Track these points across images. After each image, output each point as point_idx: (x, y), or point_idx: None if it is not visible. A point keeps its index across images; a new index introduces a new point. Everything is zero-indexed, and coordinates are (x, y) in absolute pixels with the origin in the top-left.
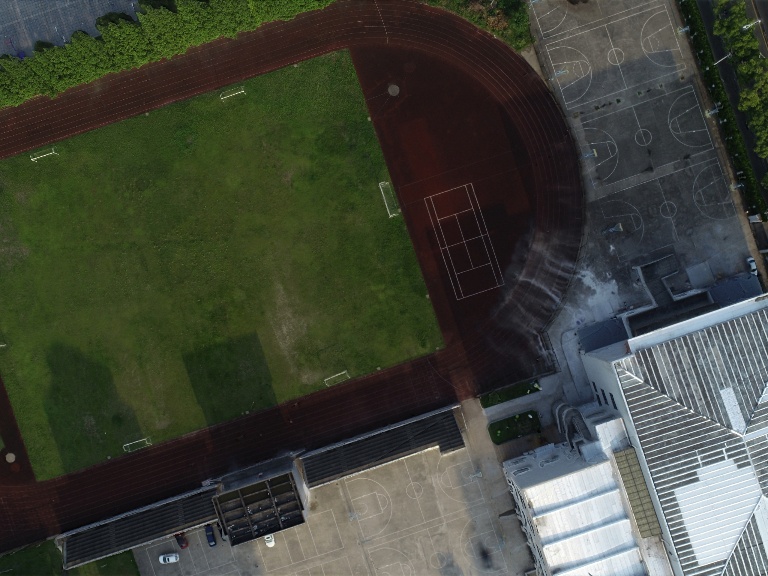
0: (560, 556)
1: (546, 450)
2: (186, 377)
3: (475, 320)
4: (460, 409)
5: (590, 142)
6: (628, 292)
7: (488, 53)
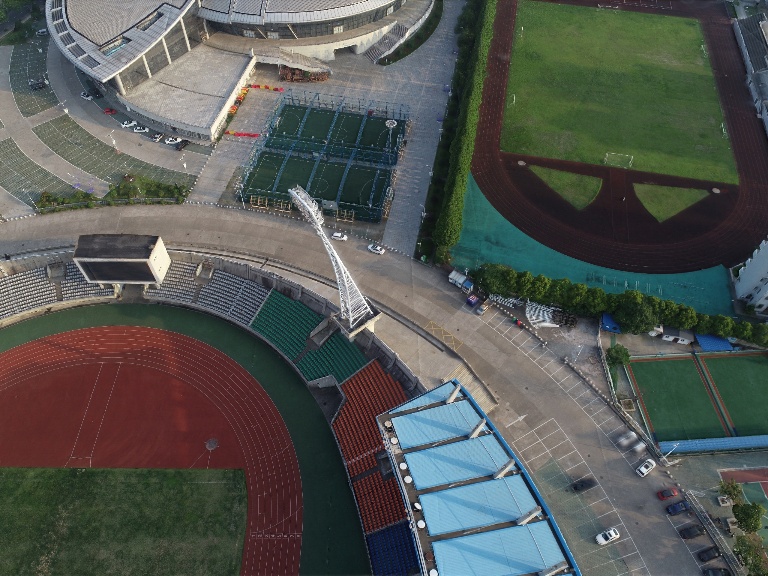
0: None
1: None
2: (683, 101)
3: (685, 8)
4: (737, 19)
5: None
6: None
7: None
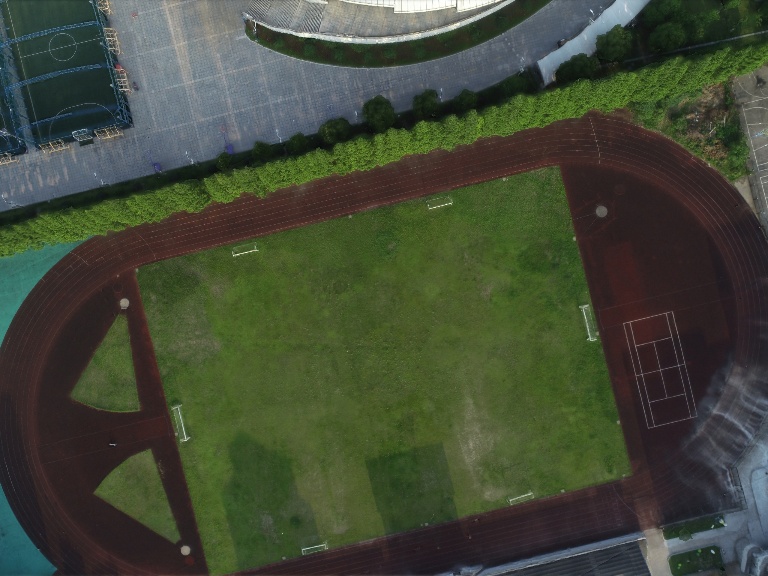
0: None
1: None
2: (368, 484)
3: (664, 450)
4: (645, 541)
5: None
6: None
7: (701, 181)
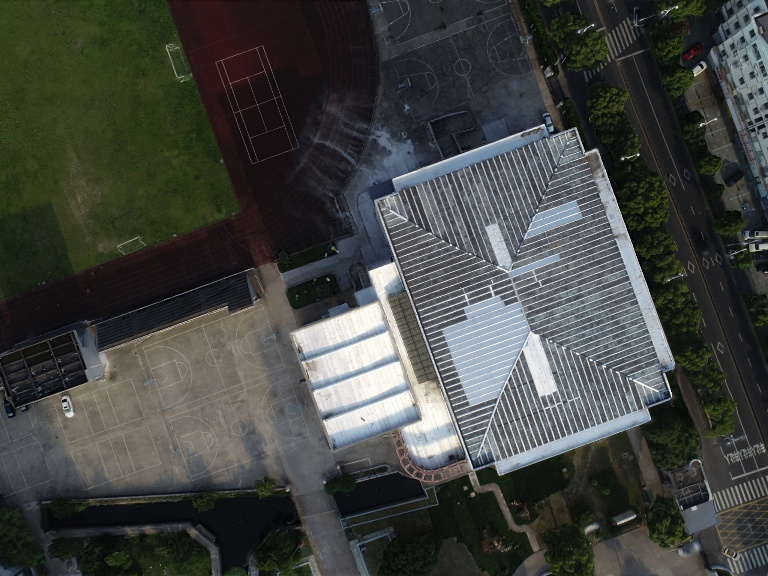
0: (332, 401)
1: (339, 310)
2: None
3: (271, 184)
4: (253, 272)
5: (382, 1)
6: (424, 152)
7: None
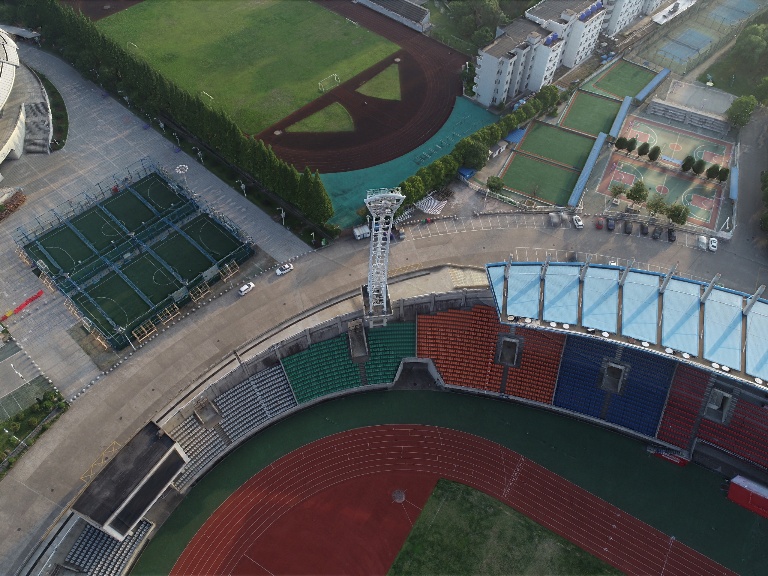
0: None
1: None
2: None
3: None
4: None
5: None
6: None
7: None
